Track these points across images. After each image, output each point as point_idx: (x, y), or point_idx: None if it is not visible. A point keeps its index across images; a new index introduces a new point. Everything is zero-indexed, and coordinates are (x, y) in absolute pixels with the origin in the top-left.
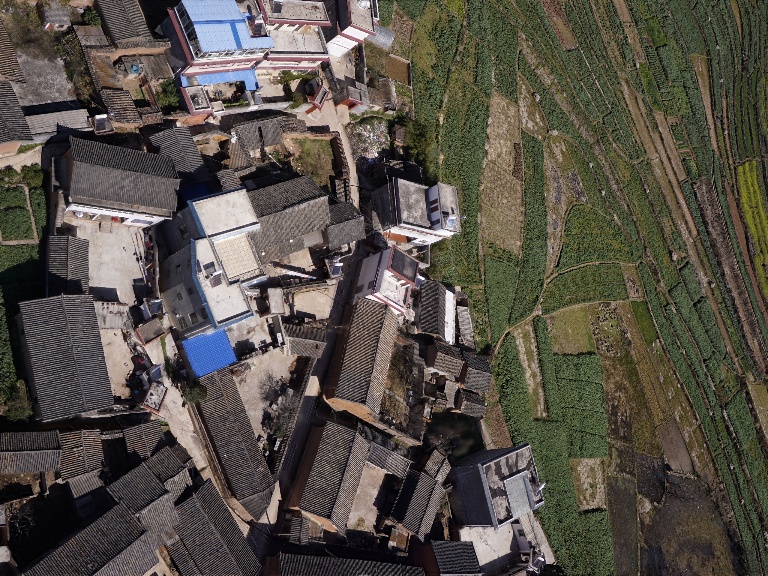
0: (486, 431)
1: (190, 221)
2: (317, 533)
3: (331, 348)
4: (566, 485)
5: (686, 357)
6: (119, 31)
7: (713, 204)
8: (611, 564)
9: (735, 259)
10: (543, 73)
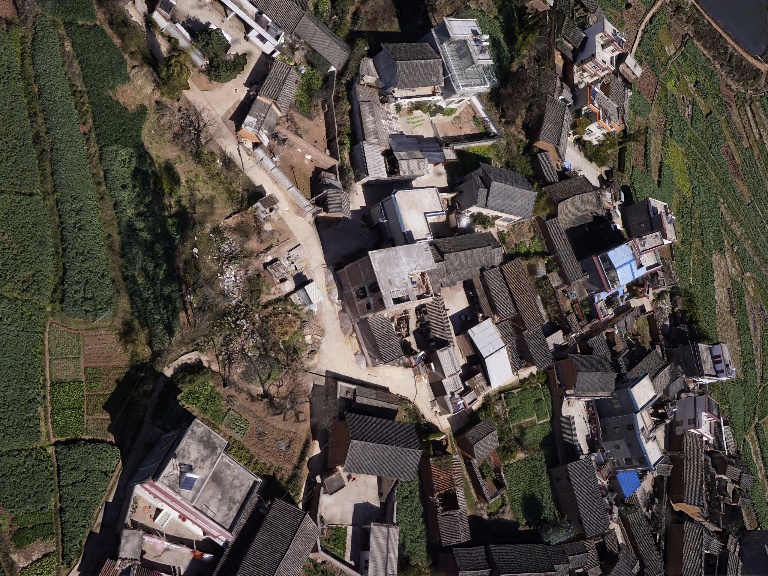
0: (745, 516)
1: (625, 399)
2: None
3: None
4: None
5: None
6: (572, 276)
7: None
8: None
9: None
10: (735, 227)
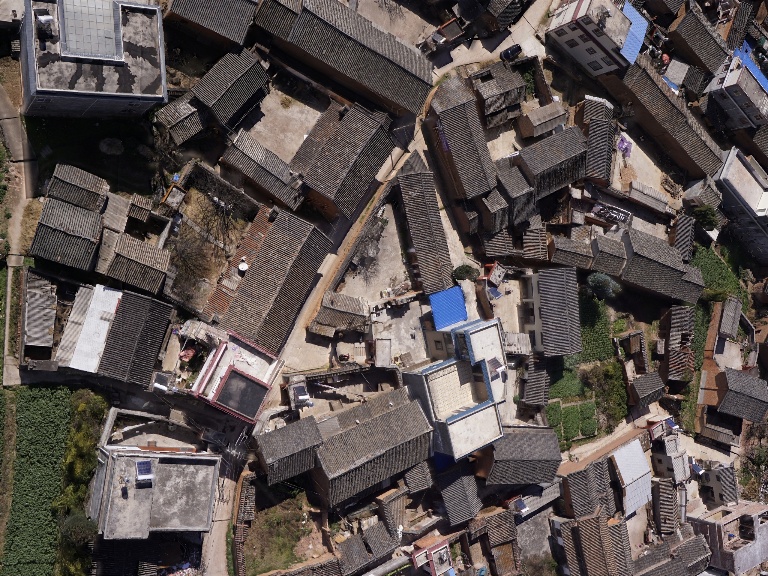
0: (13, 140)
1: None
2: None
3: None
4: None
5: None
6: None
7: None
8: None
9: None
10: None
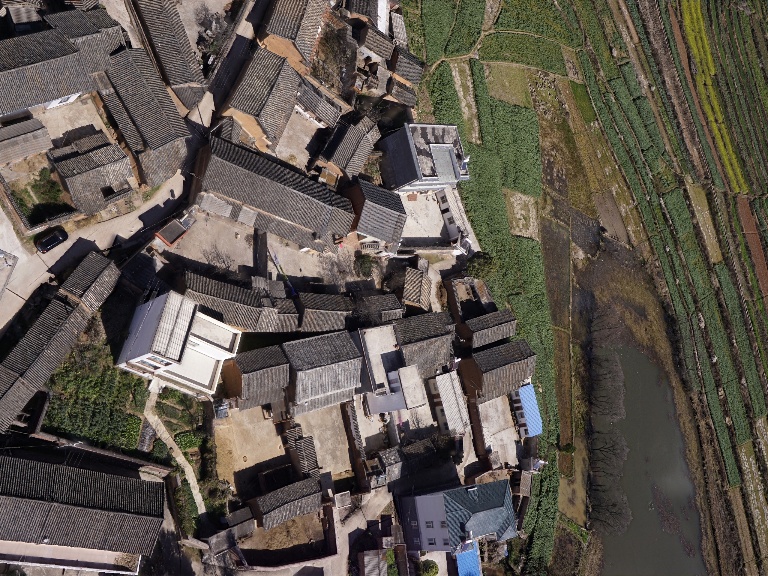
0: None
1: None
2: (248, 142)
3: (266, 5)
4: (498, 204)
5: (624, 143)
6: None
7: (655, 19)
8: (542, 286)
9: (676, 72)
10: None
